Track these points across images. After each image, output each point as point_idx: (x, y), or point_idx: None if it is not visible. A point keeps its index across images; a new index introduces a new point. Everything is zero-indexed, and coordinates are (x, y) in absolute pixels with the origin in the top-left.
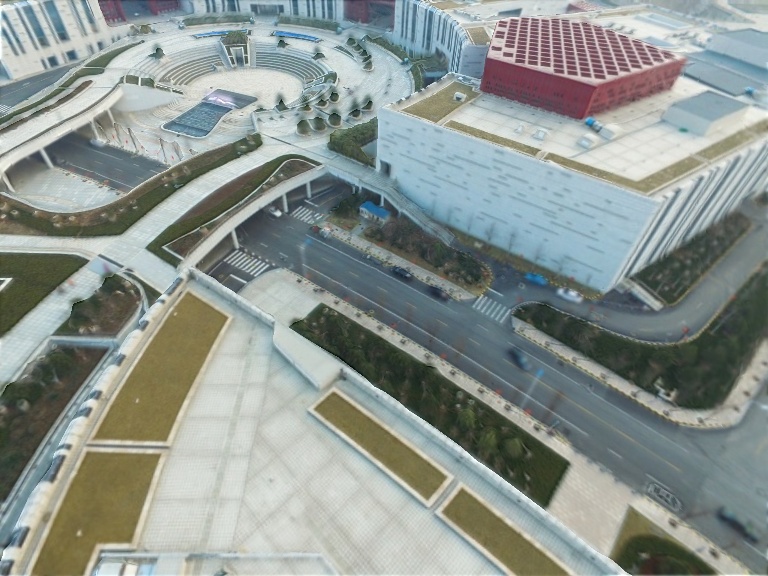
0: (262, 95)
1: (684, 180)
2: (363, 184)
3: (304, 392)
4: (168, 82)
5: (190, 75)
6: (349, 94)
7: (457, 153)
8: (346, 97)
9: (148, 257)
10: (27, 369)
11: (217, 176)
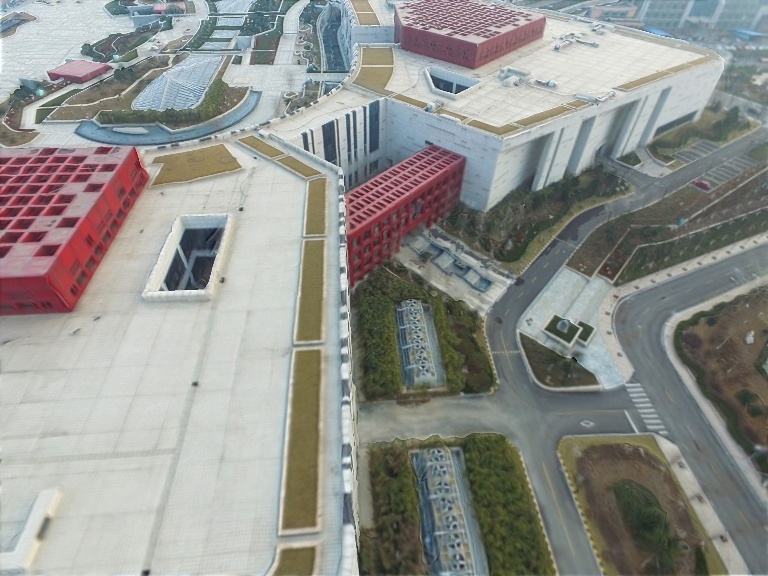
0: None
1: None
2: None
3: None
4: None
5: None
6: None
7: None
8: None
9: None
10: None
11: None
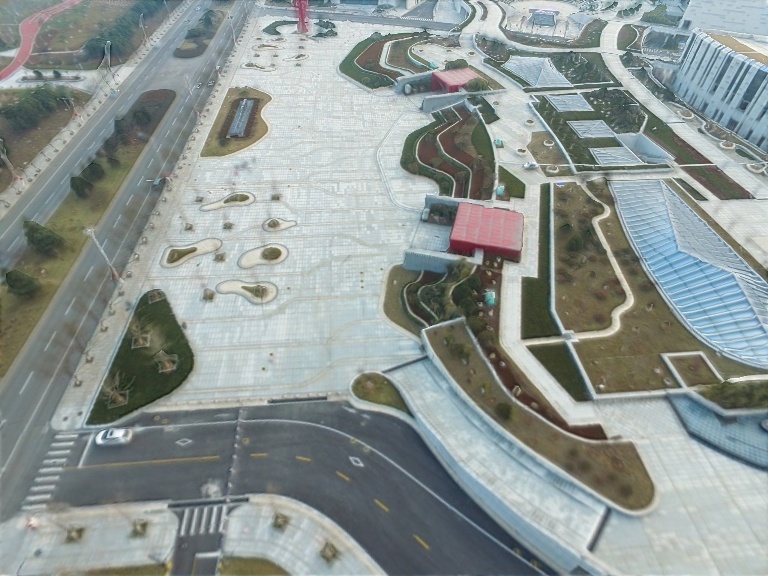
0: (558, 10)
1: None
2: (678, 32)
3: None
4: None
5: None
6: None
7: (744, 4)
8: None
9: None
10: None
11: None
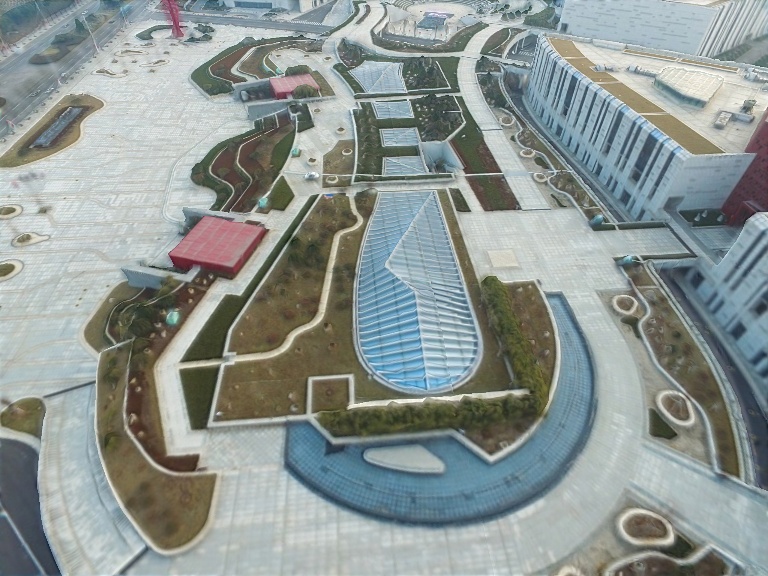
0: (454, 13)
1: (725, 4)
2: None
3: (616, 51)
4: (400, 7)
5: (404, 6)
6: (510, 7)
7: (613, 7)
8: (510, 8)
9: (485, 56)
10: (479, 79)
11: (484, 33)
